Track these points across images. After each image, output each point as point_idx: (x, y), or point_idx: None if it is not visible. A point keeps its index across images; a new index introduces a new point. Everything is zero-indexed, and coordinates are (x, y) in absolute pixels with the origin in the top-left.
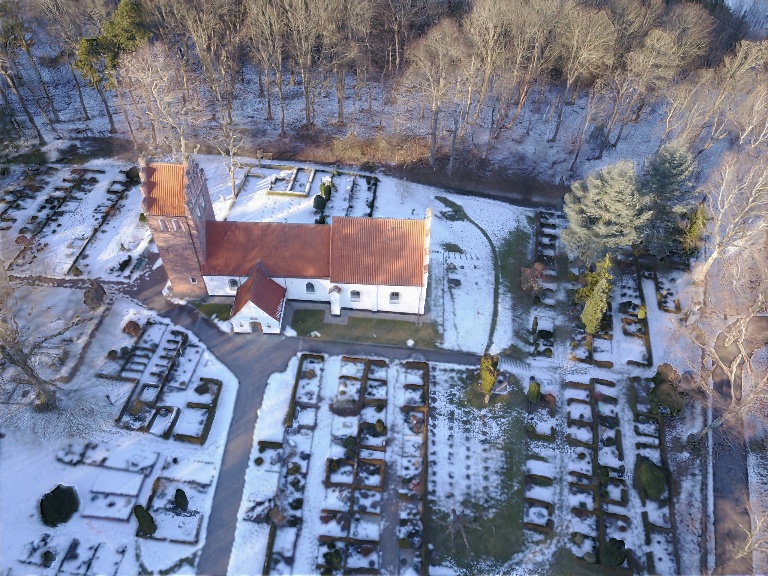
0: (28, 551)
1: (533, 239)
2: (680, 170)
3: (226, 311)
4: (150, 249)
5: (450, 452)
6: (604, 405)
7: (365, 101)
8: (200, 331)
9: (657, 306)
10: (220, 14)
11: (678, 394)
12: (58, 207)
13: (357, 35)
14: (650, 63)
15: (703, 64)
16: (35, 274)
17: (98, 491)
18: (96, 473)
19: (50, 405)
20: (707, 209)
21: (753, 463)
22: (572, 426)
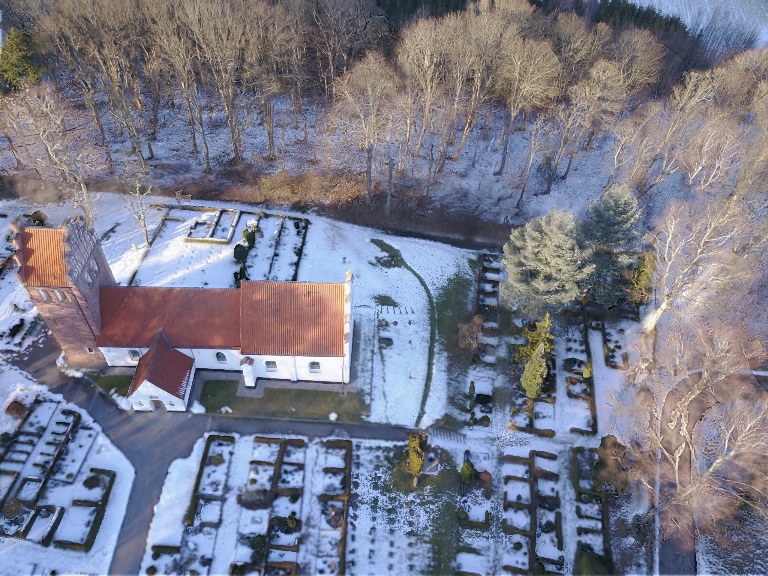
0: None
1: (475, 286)
2: (625, 218)
3: (127, 384)
4: None
5: (371, 549)
6: (544, 482)
7: (302, 130)
8: (96, 409)
9: (604, 361)
10: (126, 46)
11: (622, 471)
12: None
13: (283, 66)
14: (597, 95)
15: (654, 93)
16: None
17: None
18: None
19: None
20: None
21: (702, 548)
22: (508, 509)
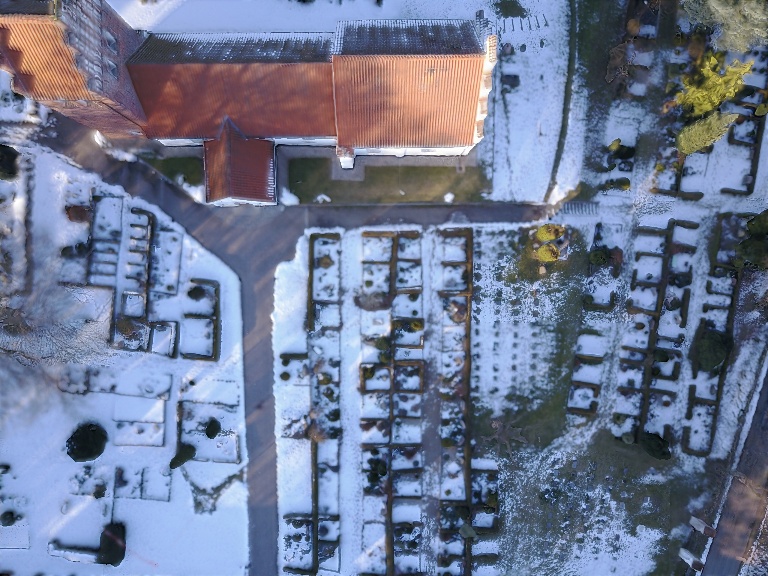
0: (76, 486)
1: None
2: None
3: (196, 170)
4: None
5: (495, 342)
6: (679, 256)
7: None
8: (169, 205)
9: None
10: None
11: None
12: None
13: None
14: None
15: None
16: None
17: (120, 420)
18: (110, 400)
19: (21, 328)
20: None
21: None
22: (636, 288)
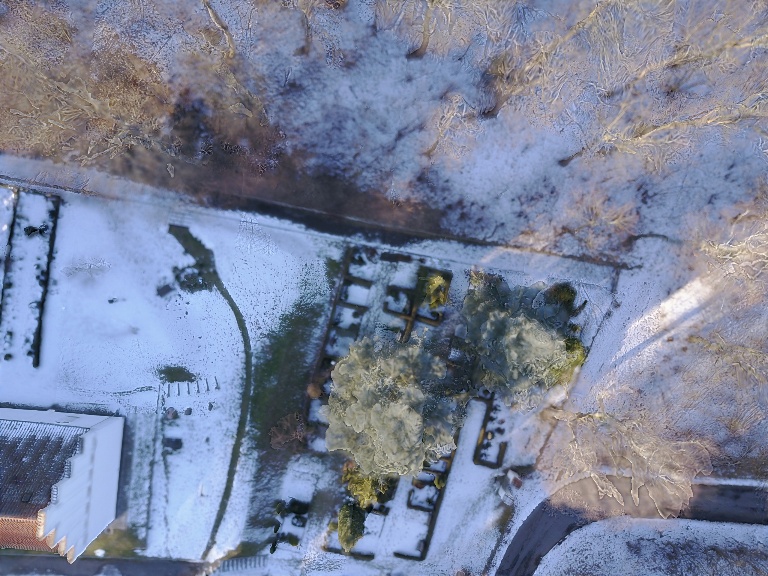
0: None
1: (327, 312)
2: (533, 374)
3: None
4: None
5: None
6: None
7: None
8: None
9: (473, 453)
10: None
11: None
12: None
13: None
14: None
15: None
16: None
17: None
18: None
19: None
20: (640, 245)
21: None
22: None
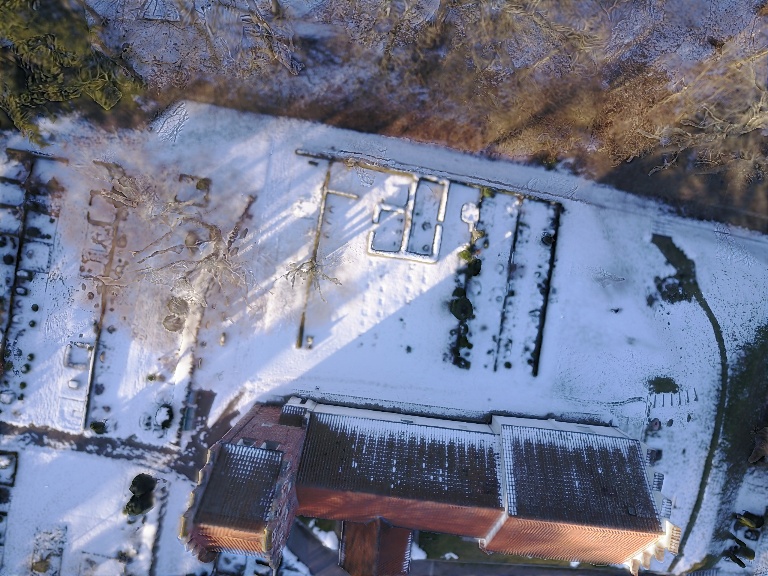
0: None
1: None
2: None
3: None
4: (195, 385)
5: None
6: None
7: None
8: (297, 545)
9: None
10: None
11: None
12: (17, 259)
13: None
14: None
15: None
16: (37, 422)
17: None
18: None
19: None
20: None
21: None
22: None
